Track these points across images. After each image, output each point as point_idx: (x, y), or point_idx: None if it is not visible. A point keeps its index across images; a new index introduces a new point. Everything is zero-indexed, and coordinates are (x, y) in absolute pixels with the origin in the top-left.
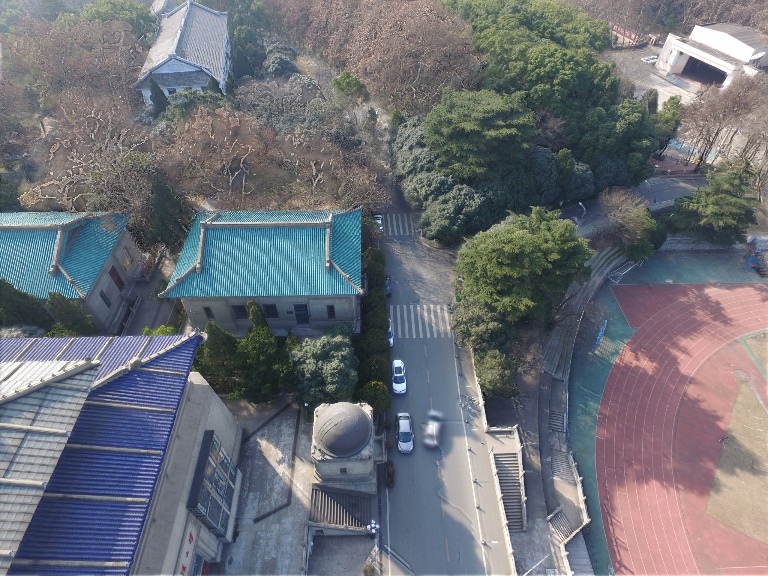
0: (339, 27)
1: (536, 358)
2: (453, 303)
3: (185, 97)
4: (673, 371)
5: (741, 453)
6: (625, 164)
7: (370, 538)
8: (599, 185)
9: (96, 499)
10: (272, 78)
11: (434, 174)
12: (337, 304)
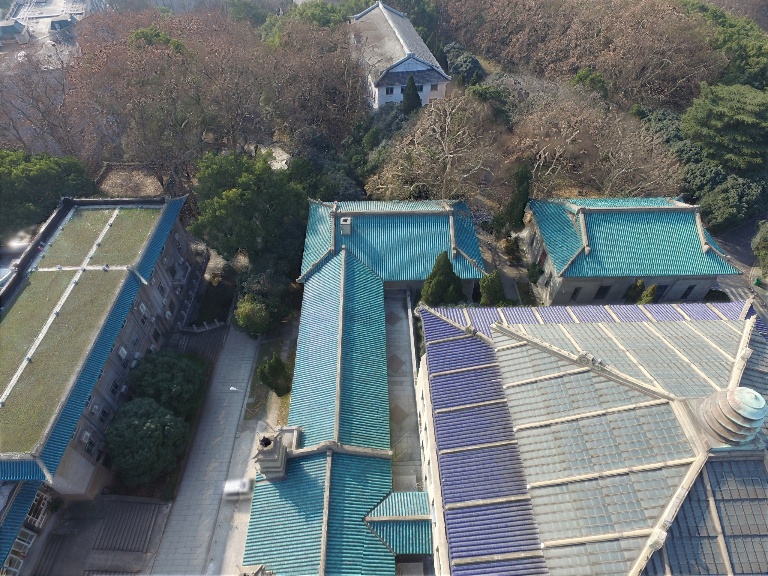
0: (526, 27)
1: None
2: (752, 287)
3: (485, 92)
4: None
5: None
6: None
7: None
8: None
9: None
10: None
11: (704, 165)
12: (700, 284)
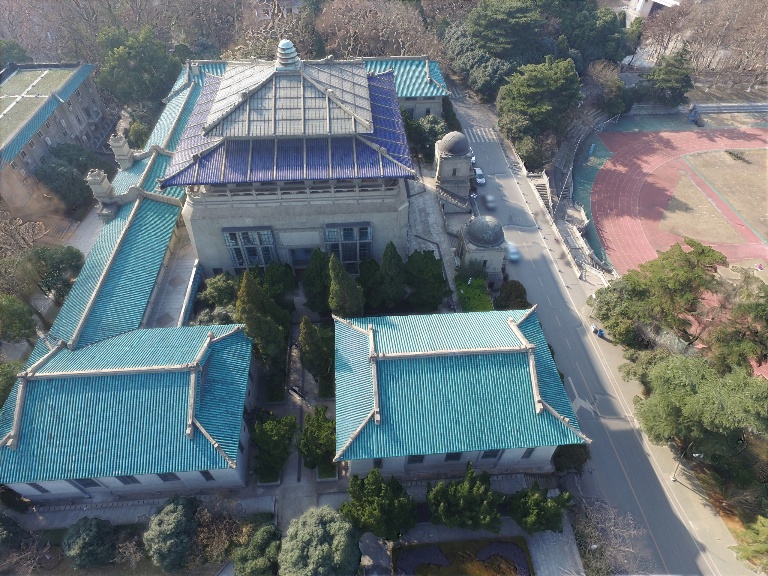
0: None
1: (553, 143)
2: (496, 127)
3: None
4: (638, 171)
5: (680, 204)
6: (603, 51)
7: (469, 213)
8: (586, 66)
9: (381, 105)
10: None
11: (476, 52)
12: (432, 108)
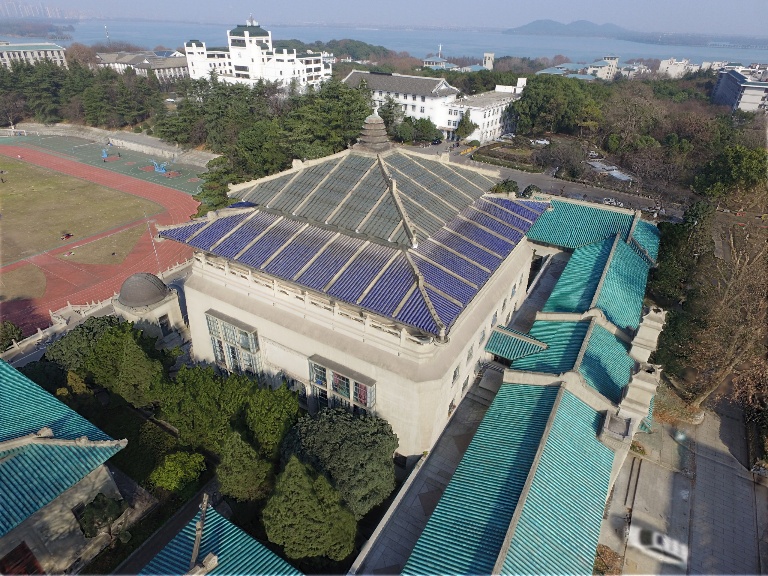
0: None
1: None
2: None
3: None
4: None
5: None
6: None
7: None
8: None
9: None
10: None
11: None
12: None
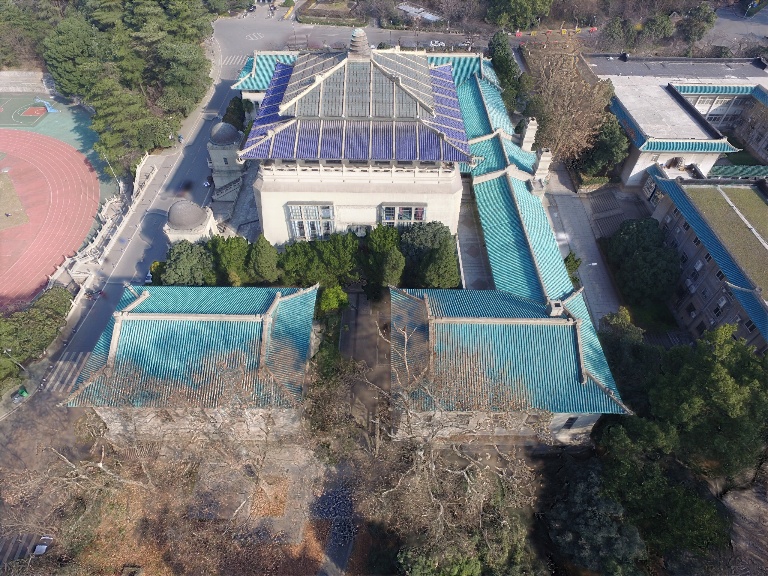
0: None
1: (5, 310)
2: (34, 392)
3: None
4: None
5: None
6: None
7: None
8: None
9: None
10: None
11: None
12: None
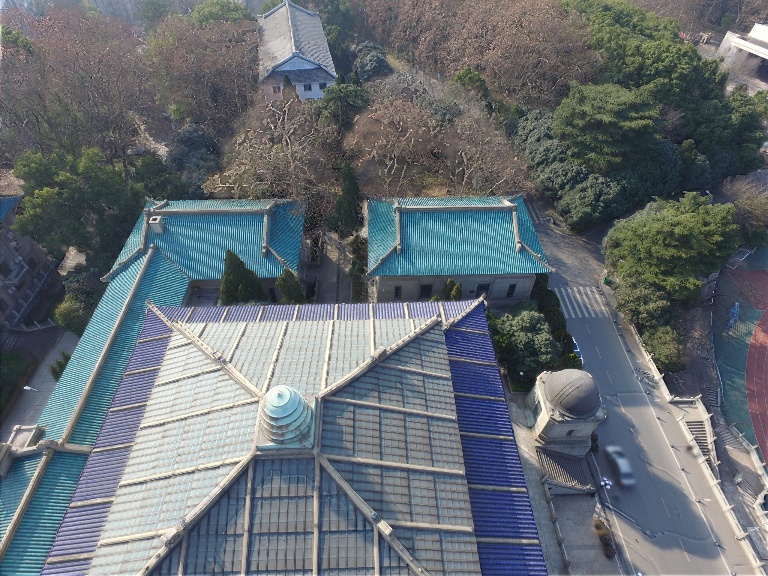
0: (433, 26)
1: (702, 334)
2: (601, 285)
3: (340, 91)
4: None
5: None
6: (738, 155)
7: (590, 497)
8: (714, 175)
9: (478, 436)
10: (370, 76)
11: (568, 164)
12: (520, 283)
